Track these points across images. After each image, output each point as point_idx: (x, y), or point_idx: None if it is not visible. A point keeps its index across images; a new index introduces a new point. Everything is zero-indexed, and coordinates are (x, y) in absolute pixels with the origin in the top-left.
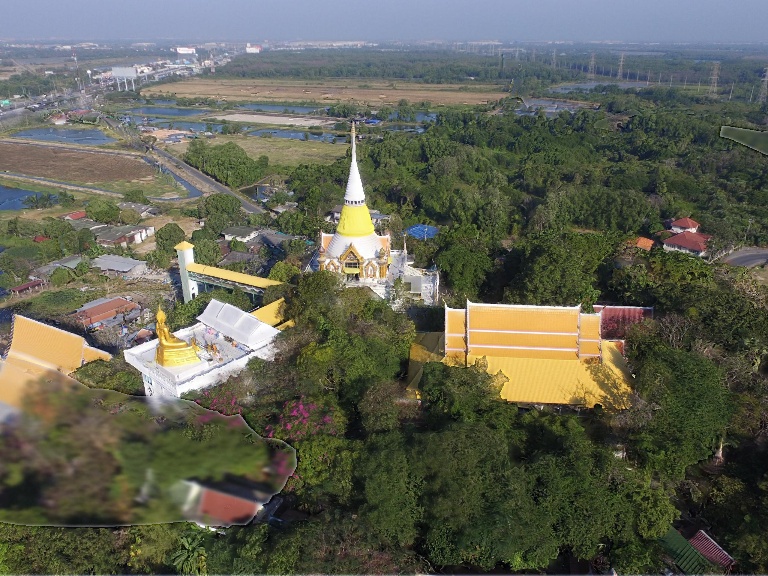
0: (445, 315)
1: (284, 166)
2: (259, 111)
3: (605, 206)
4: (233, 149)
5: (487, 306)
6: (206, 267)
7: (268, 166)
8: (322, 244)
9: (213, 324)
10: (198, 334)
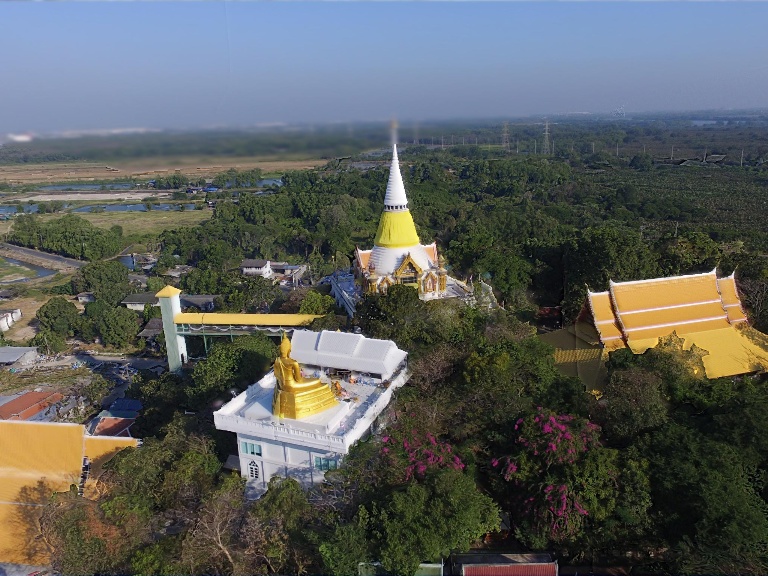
0: (590, 301)
1: (142, 235)
2: (69, 190)
3: (516, 230)
4: (77, 221)
5: (630, 284)
6: (204, 314)
7: (122, 237)
8: (361, 263)
9: (314, 360)
10: None
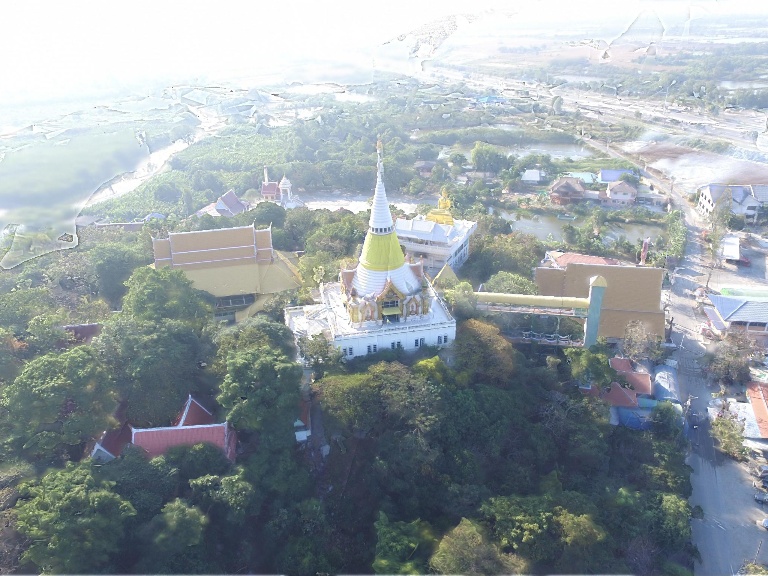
0: None
1: None
2: None
3: None
4: None
5: (240, 228)
6: None
7: None
8: None
9: None
10: (455, 240)
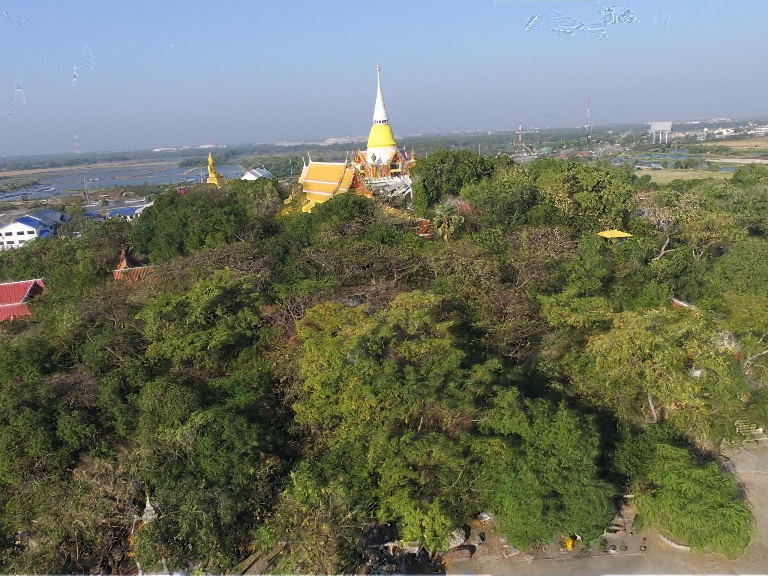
0: None
1: (664, 185)
2: (763, 156)
3: None
4: (620, 167)
5: None
6: None
7: None
8: None
9: None
10: None
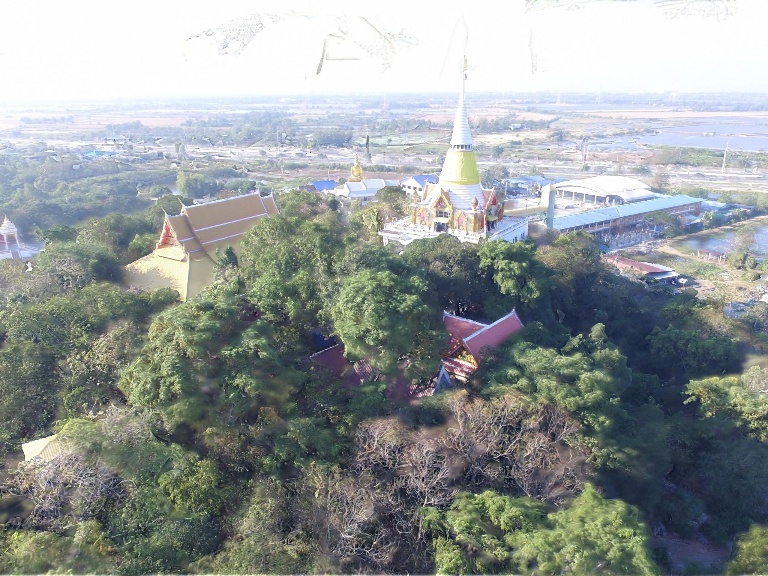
0: None
1: None
2: None
3: None
4: None
5: (247, 196)
6: None
7: None
8: None
9: None
10: None
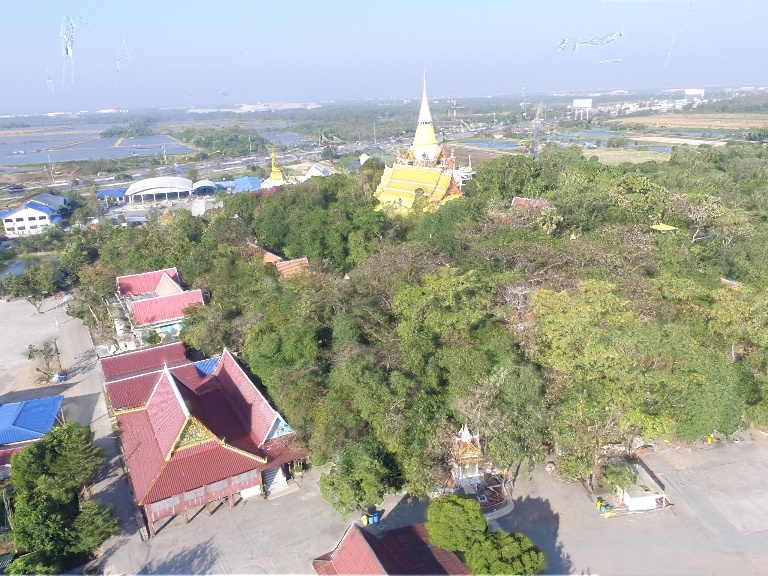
0: (384, 171)
1: None
2: (677, 135)
3: None
4: (570, 149)
5: None
6: None
7: None
8: None
9: None
10: None
